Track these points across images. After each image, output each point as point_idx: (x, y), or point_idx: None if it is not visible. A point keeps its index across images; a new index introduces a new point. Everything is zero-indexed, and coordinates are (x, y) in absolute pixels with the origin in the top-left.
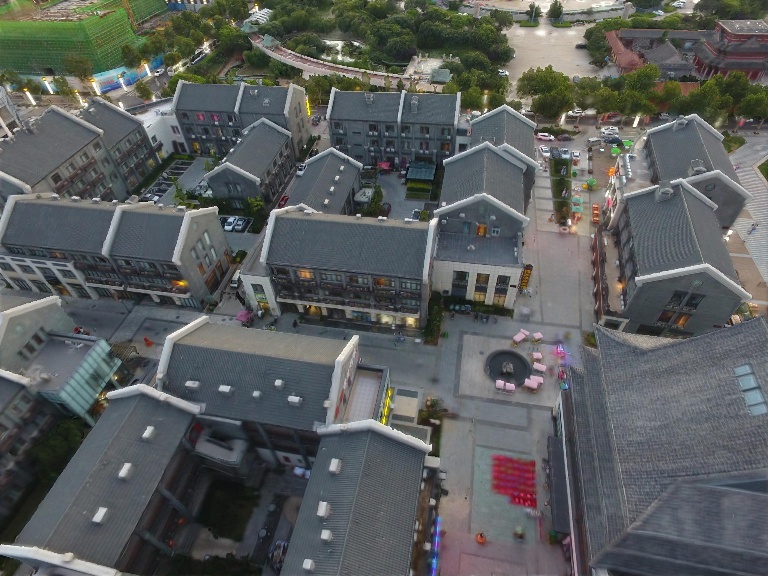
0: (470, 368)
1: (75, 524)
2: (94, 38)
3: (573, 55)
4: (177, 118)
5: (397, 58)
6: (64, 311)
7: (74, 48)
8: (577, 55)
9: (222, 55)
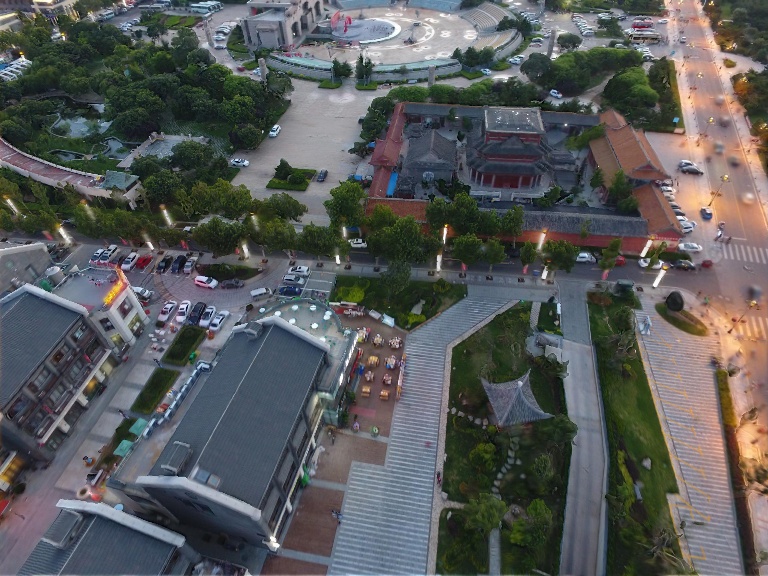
0: None
1: None
2: None
3: (348, 134)
4: None
5: None
6: None
7: None
8: (353, 134)
9: None
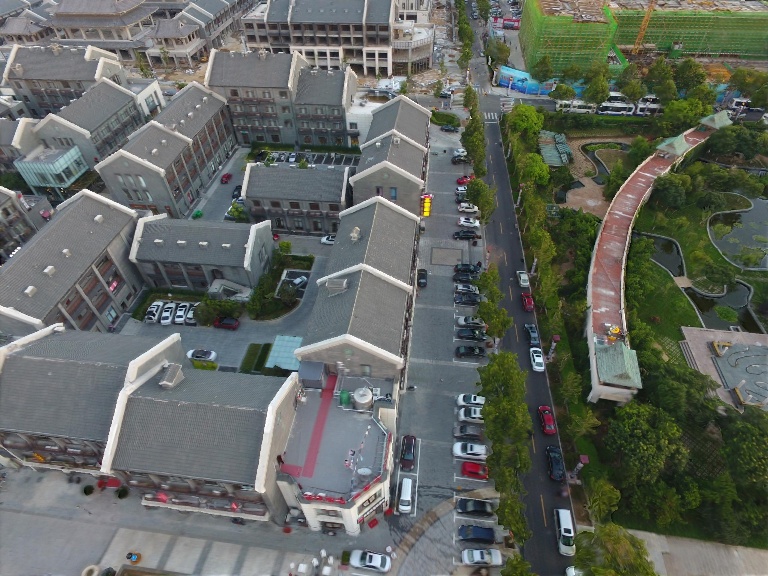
0: None
1: None
2: (546, 37)
3: None
4: None
5: (759, 308)
6: None
7: None
8: None
9: (644, 126)
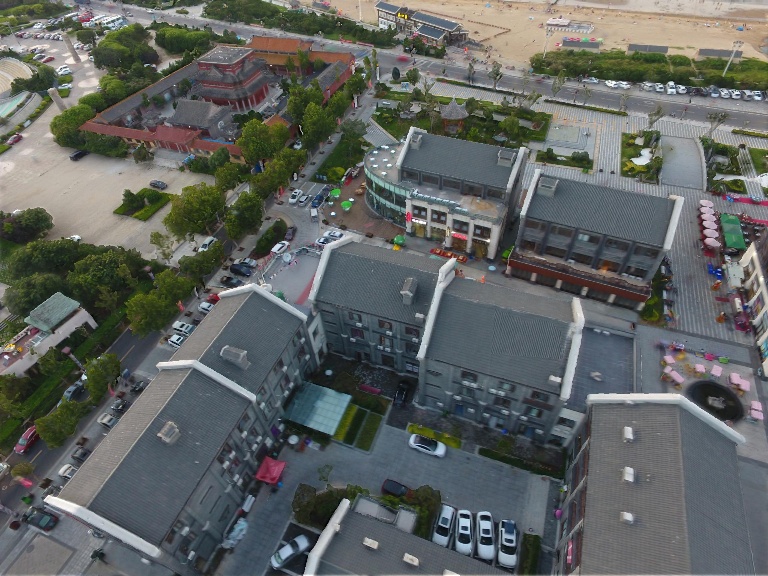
0: None
1: None
2: None
3: None
4: None
5: None
6: None
7: None
8: (93, 166)
9: None
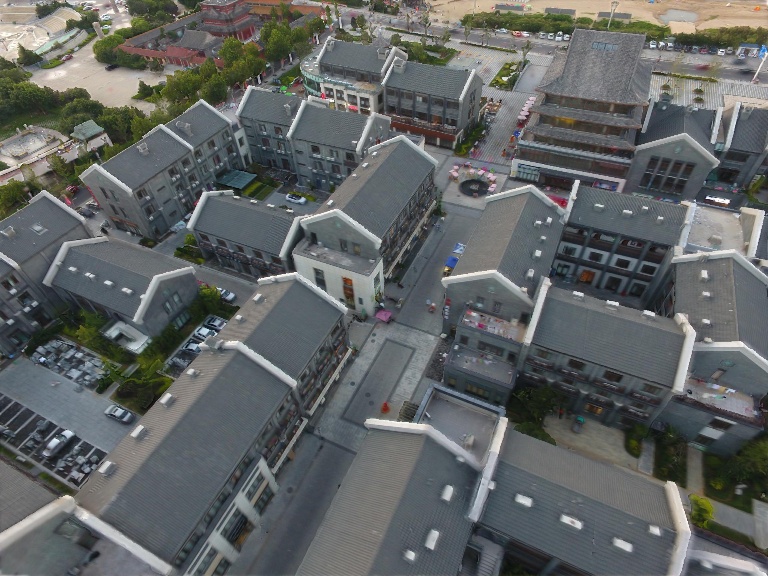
0: (470, 203)
1: None
2: None
3: (118, 75)
4: None
5: None
6: (281, 535)
7: None
8: (121, 74)
9: None
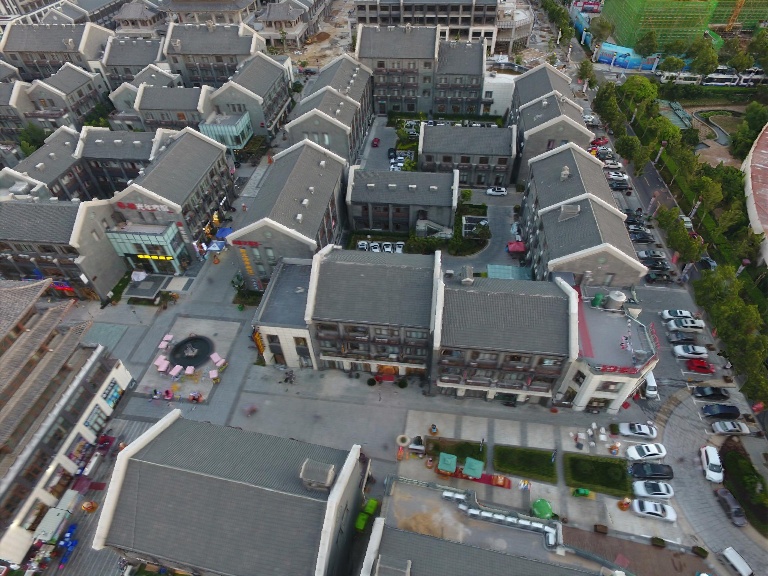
0: (201, 325)
1: (98, 136)
2: (647, 15)
3: None
4: (514, 90)
5: None
6: None
7: (630, 17)
8: None
9: (749, 95)
